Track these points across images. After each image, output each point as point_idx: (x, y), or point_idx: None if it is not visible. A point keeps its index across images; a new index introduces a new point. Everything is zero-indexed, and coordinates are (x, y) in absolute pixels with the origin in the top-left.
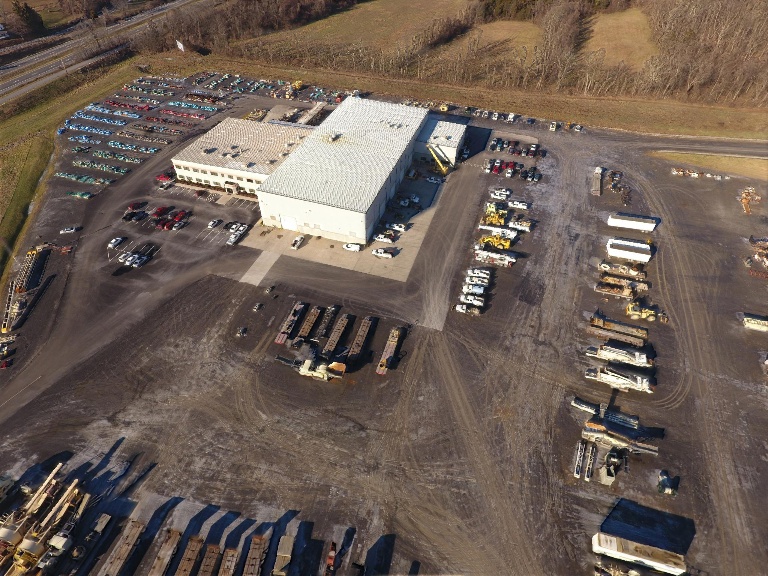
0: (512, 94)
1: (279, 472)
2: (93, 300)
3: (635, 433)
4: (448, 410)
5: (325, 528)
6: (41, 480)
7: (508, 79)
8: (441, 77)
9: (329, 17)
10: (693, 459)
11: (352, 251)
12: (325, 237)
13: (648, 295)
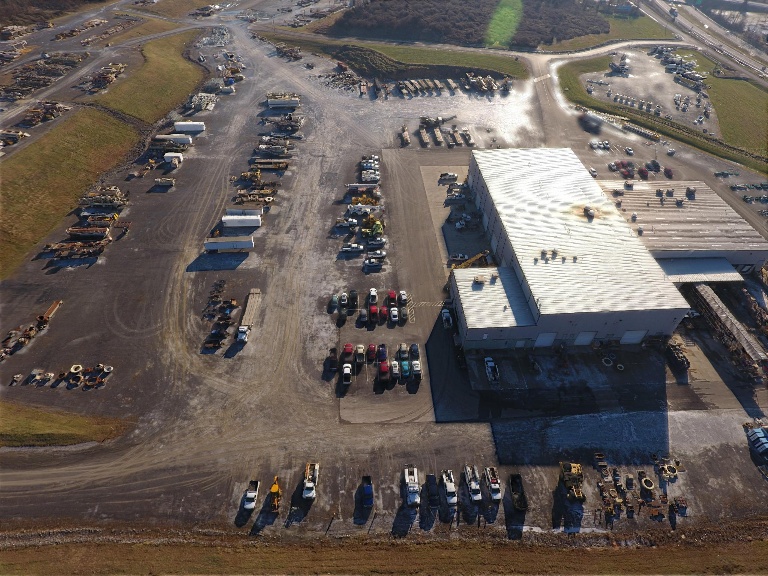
0: None
1: (423, 104)
2: (583, 128)
3: None
4: (365, 126)
5: (396, 98)
6: (502, 92)
7: None
8: None
9: None
10: None
11: None
12: None
13: None
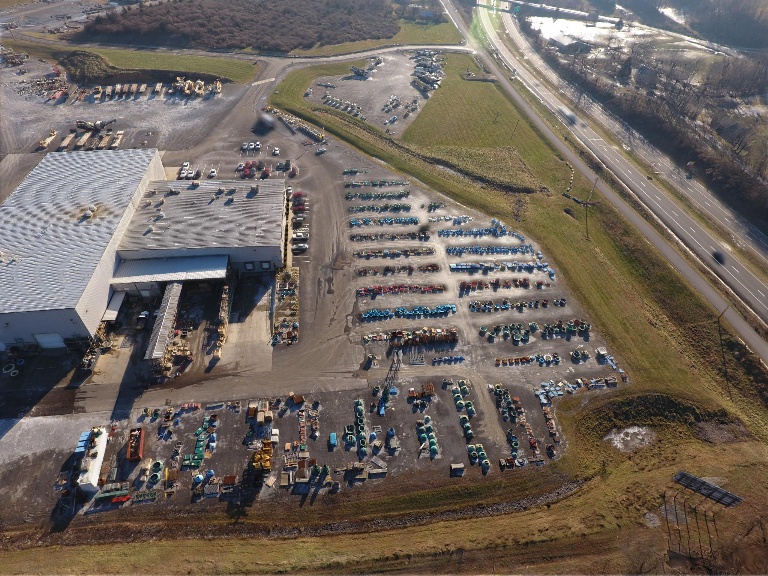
0: None
1: None
2: None
3: None
4: None
5: (83, 103)
6: None
7: None
8: None
9: None
10: None
11: None
12: None
13: None
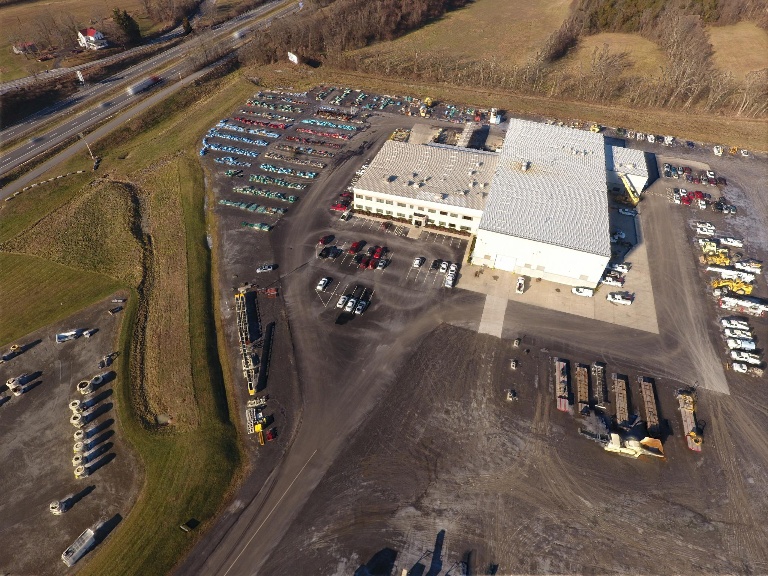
0: (658, 114)
1: None
2: (330, 354)
3: None
4: None
5: None
6: None
7: (653, 98)
8: (577, 95)
9: (425, 27)
10: None
11: (583, 296)
12: (546, 279)
13: None
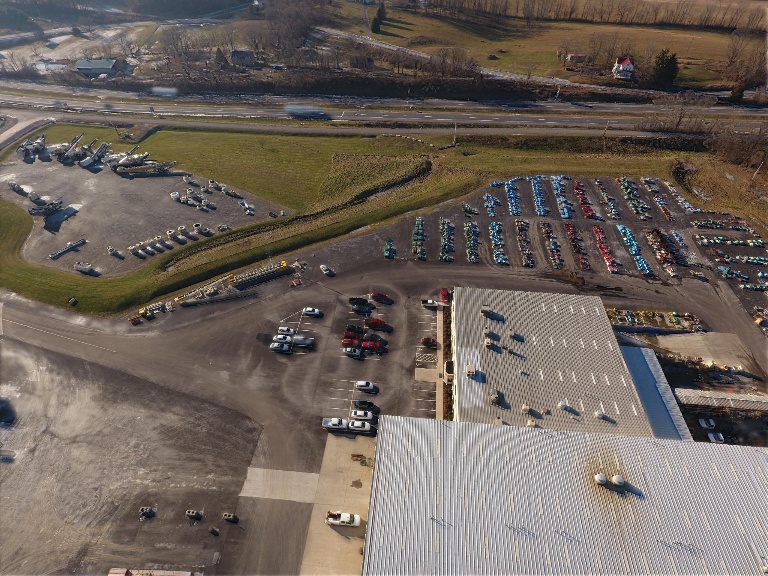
0: None
1: None
2: (218, 338)
3: None
4: None
5: None
6: None
7: None
8: None
9: None
10: None
11: None
12: None
13: None
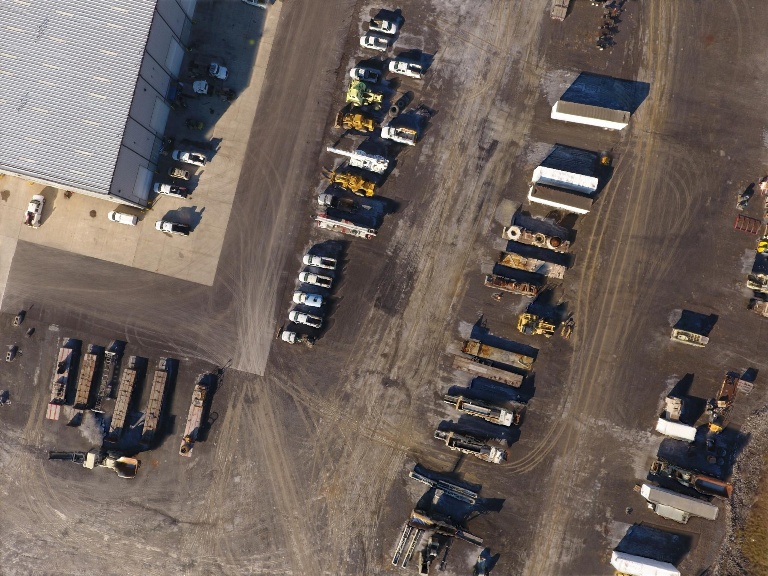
0: None
1: None
2: None
3: (471, 507)
4: (267, 493)
5: None
6: None
7: None
8: None
9: None
10: (522, 534)
11: (125, 224)
12: (77, 192)
13: (561, 284)
